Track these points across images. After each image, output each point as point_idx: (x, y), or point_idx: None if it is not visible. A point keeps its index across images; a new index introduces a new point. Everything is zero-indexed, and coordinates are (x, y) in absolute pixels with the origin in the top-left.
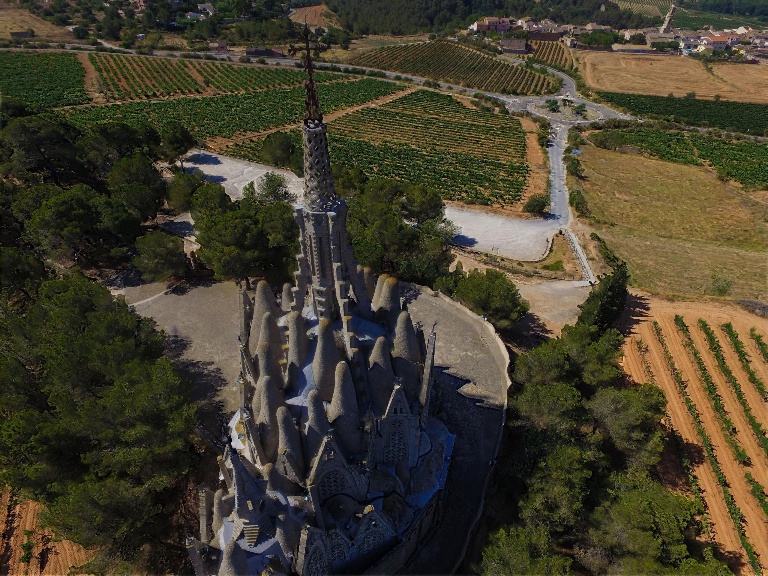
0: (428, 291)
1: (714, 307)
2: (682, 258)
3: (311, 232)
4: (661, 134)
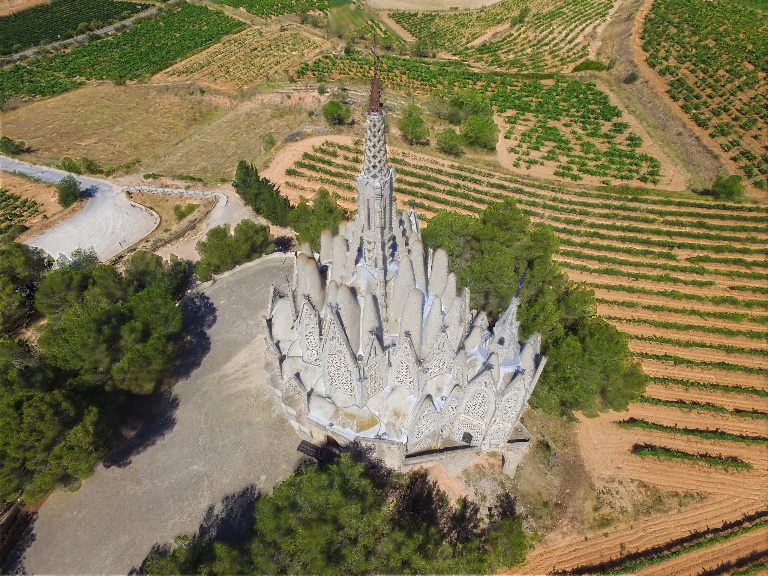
0: (206, 285)
1: (284, 153)
2: (210, 147)
3: (387, 195)
4: (5, 75)
